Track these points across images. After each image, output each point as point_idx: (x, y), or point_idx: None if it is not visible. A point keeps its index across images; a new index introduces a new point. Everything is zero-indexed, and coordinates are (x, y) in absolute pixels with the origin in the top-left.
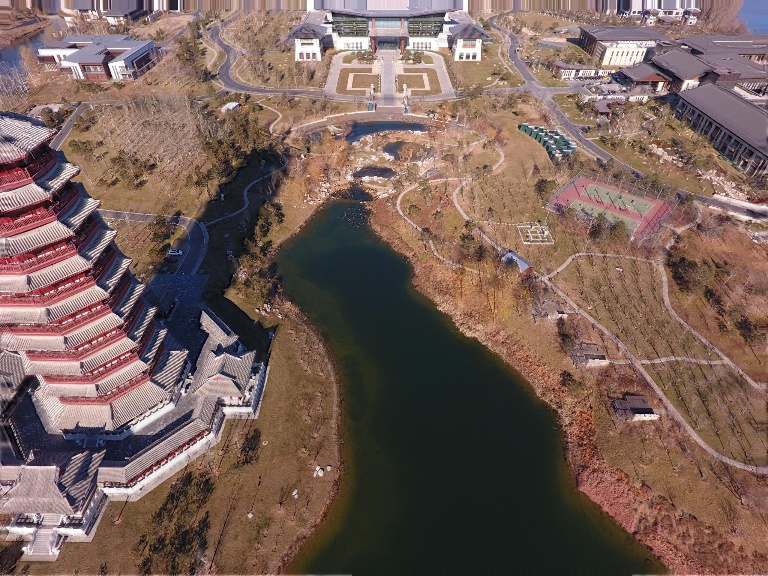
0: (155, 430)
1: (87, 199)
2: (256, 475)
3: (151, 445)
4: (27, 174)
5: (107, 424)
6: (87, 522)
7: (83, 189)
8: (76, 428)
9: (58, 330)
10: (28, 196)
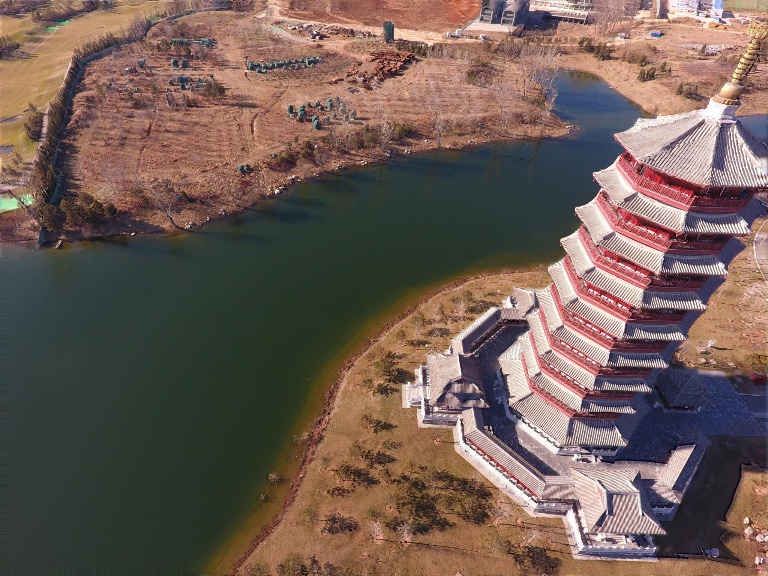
0: (525, 443)
1: (719, 261)
2: (503, 573)
3: (504, 445)
4: (691, 201)
5: (514, 398)
6: (431, 418)
7: (737, 252)
8: (504, 375)
9: (565, 317)
10: (667, 217)
